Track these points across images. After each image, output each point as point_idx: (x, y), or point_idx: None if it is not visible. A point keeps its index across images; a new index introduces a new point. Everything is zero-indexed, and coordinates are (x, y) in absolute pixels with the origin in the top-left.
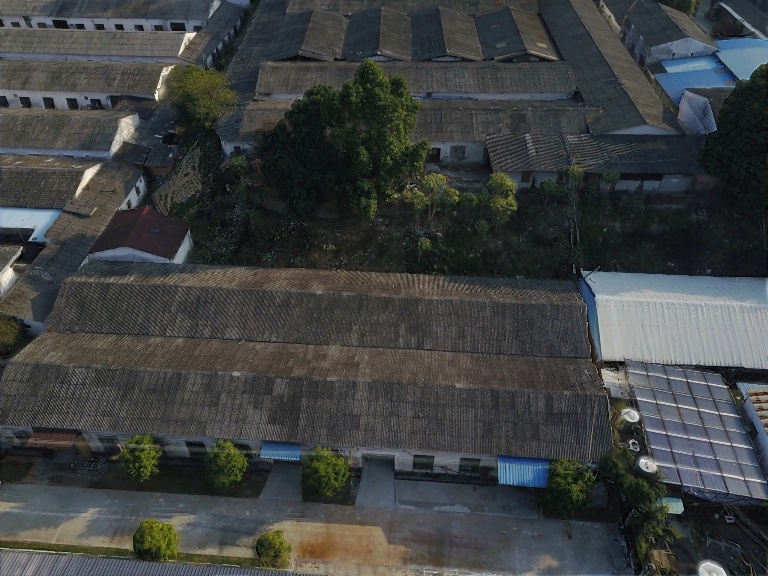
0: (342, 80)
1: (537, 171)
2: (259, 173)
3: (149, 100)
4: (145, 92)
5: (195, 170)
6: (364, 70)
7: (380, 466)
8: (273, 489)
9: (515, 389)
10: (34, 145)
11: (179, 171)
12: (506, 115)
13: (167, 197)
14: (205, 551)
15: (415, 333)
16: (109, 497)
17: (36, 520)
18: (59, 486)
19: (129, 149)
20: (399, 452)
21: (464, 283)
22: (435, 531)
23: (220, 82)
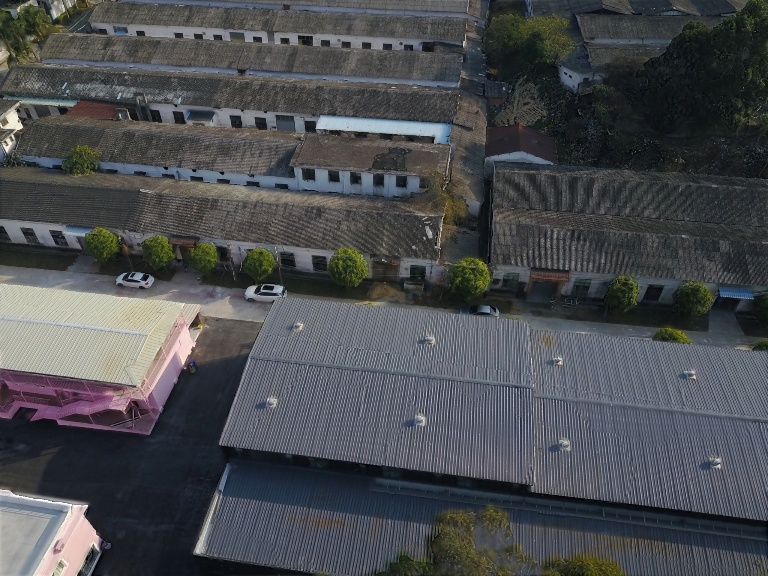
0: (655, 28)
1: None
2: (615, 99)
3: (458, 46)
4: (456, 39)
5: (536, 100)
6: (755, 6)
7: None
8: (717, 326)
9: None
10: (394, 76)
11: (514, 102)
12: None
13: (509, 122)
14: None
15: None
16: (587, 326)
17: None
18: (542, 317)
19: (467, 83)
20: None
21: None
22: None
23: (567, 24)
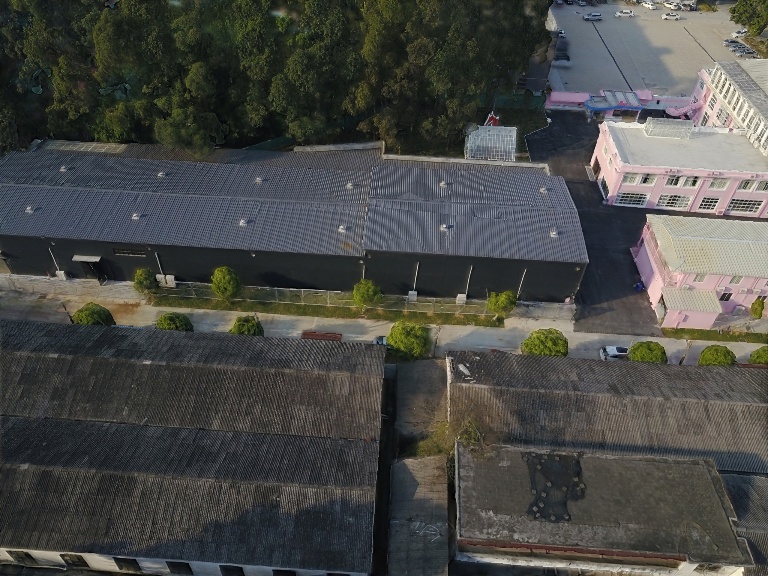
0: None
1: None
2: None
3: None
4: None
5: None
6: None
7: None
8: None
9: None
10: None
11: None
12: None
13: None
14: (204, 311)
15: None
16: None
17: (335, 329)
18: None
19: None
20: None
21: None
22: (29, 318)
23: None
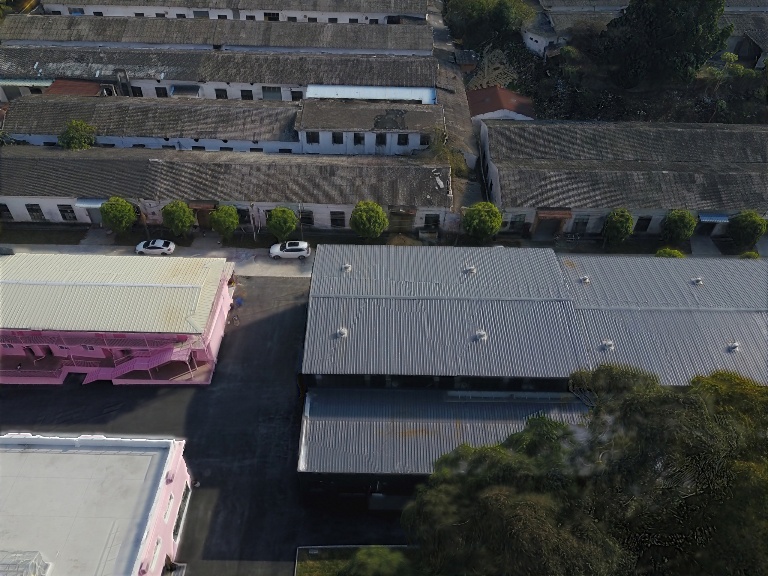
0: None
1: None
2: (580, 59)
3: (421, 19)
4: (419, 12)
5: (505, 64)
6: None
7: (763, 235)
8: (699, 249)
9: None
10: (370, 46)
11: (484, 68)
12: (749, 18)
13: (483, 86)
14: None
15: (758, 153)
16: None
17: None
18: None
19: (438, 52)
20: None
21: None
22: None
23: None
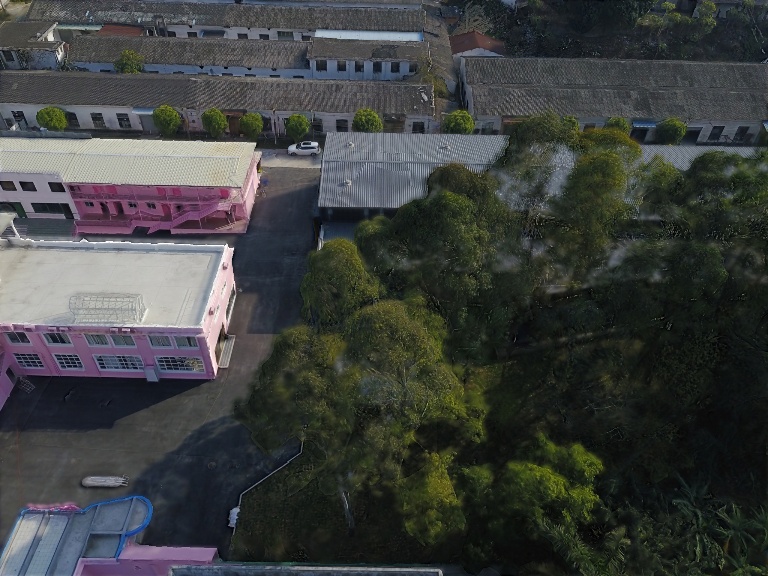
0: None
1: (725, 3)
2: (545, 9)
3: None
4: None
5: (483, 17)
6: None
7: (686, 142)
8: None
9: (762, 93)
10: (368, 1)
11: (465, 20)
12: None
13: None
14: None
15: (686, 80)
16: None
17: None
18: None
19: (426, 7)
20: (706, 124)
21: (698, 61)
22: None
23: None
